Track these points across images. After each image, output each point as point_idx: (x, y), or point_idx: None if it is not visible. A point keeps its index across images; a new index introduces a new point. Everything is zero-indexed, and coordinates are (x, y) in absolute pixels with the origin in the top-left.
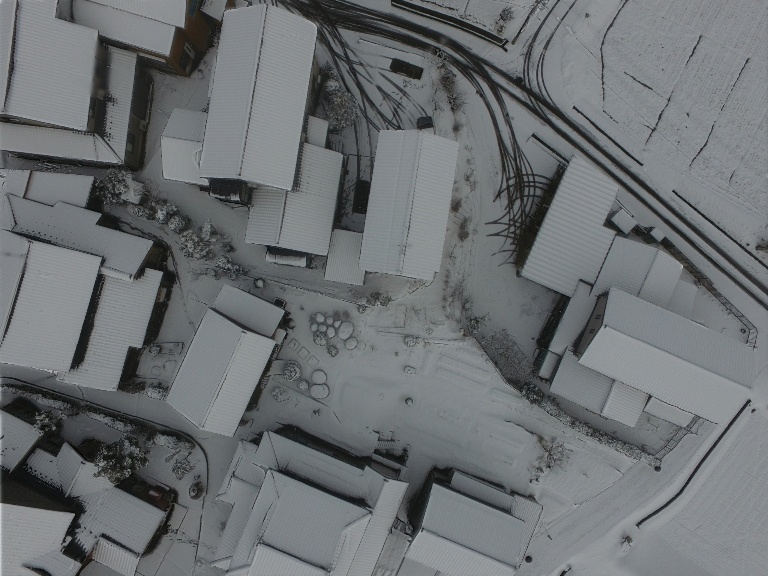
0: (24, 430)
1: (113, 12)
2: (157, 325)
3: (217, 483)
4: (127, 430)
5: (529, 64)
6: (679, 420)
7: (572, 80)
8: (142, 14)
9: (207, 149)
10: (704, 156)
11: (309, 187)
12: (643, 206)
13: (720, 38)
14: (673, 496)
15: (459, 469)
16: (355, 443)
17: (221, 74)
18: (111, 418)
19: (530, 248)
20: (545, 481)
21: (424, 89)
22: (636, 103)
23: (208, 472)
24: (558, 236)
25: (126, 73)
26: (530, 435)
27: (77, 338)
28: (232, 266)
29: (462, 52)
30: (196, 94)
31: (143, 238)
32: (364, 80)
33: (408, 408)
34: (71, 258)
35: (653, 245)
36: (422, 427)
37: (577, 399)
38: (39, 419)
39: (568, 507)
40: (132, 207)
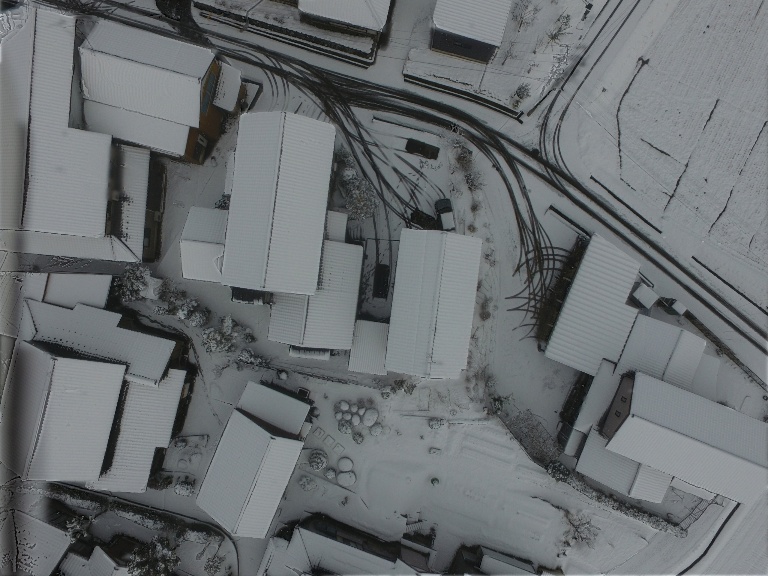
0: (55, 537)
1: (125, 113)
2: (181, 418)
3: (248, 573)
4: (157, 528)
5: (545, 135)
6: (705, 494)
7: (589, 150)
8: (155, 115)
9: (229, 257)
10: (723, 222)
11: (331, 284)
12: (663, 273)
13: (737, 102)
14: (697, 557)
15: (487, 546)
16: (384, 529)
17: (240, 180)
18: (140, 516)
19: (551, 323)
20: (571, 551)
21: (441, 169)
22: (654, 170)
23: (238, 562)
24: (580, 315)
25: (140, 171)
26: (556, 510)
27: (105, 447)
28: (255, 360)
29: (477, 126)
30: (210, 182)
31: (165, 339)
32: (380, 162)
33: (434, 488)
34: (96, 370)
35: (674, 316)
36: (449, 506)
37: (604, 480)
38: (70, 527)
39: (595, 575)
40: (151, 301)
